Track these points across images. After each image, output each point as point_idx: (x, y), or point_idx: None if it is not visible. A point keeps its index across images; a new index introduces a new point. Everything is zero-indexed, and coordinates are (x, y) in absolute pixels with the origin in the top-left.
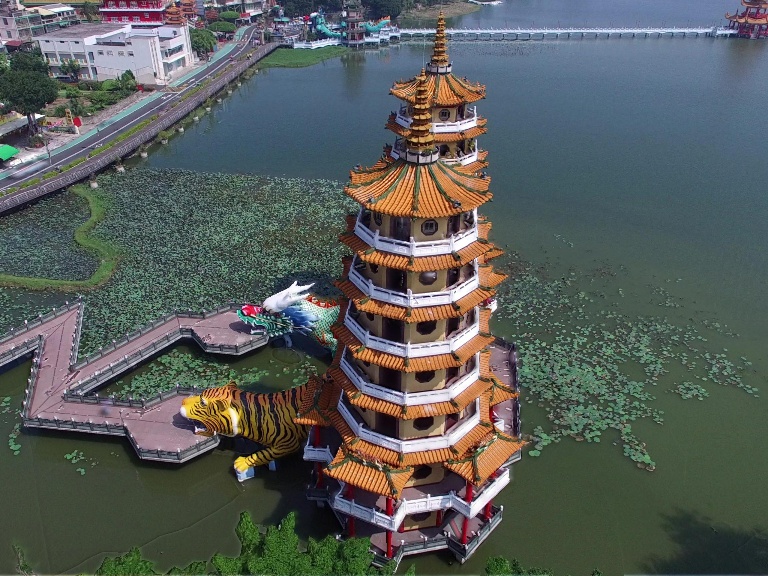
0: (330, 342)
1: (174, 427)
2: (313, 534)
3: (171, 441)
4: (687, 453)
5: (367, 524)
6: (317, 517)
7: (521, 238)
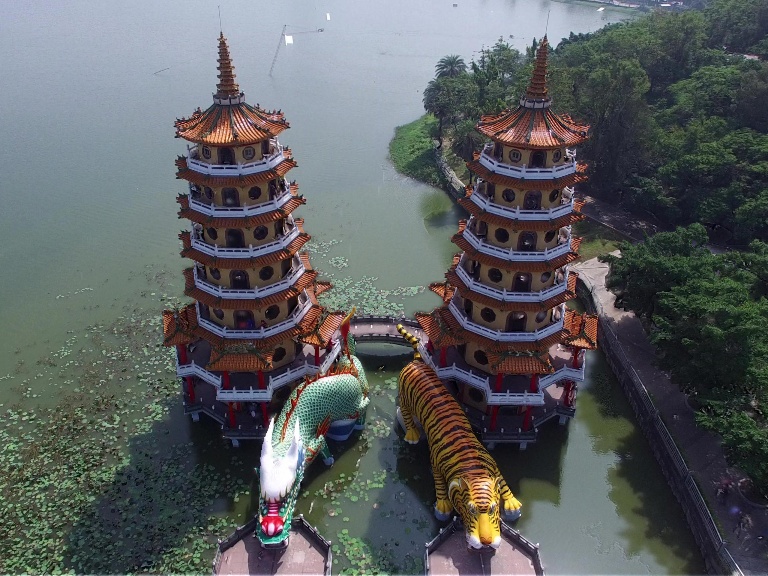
0: (320, 445)
1: None
2: (549, 453)
3: (514, 575)
4: None
5: (546, 401)
6: (529, 455)
7: (54, 321)
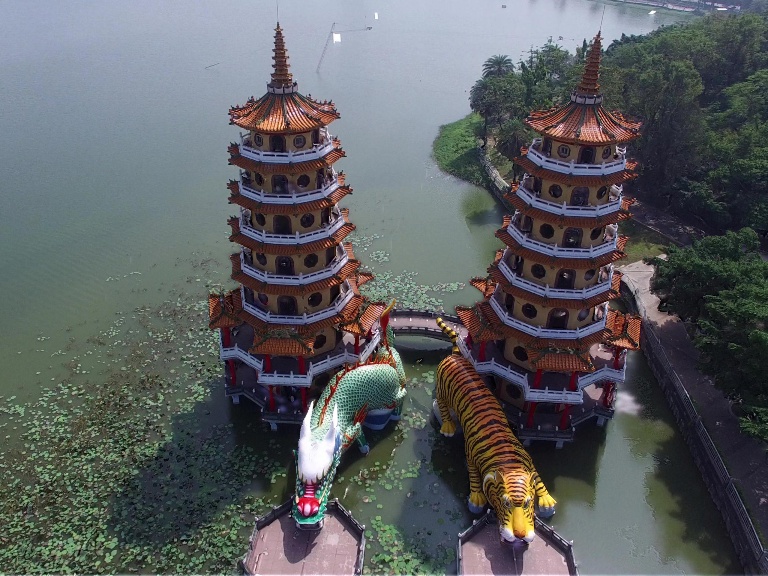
0: None
1: (524, 574)
2: (586, 453)
3: (547, 571)
4: (443, 271)
5: (585, 401)
6: (565, 454)
7: (104, 302)
